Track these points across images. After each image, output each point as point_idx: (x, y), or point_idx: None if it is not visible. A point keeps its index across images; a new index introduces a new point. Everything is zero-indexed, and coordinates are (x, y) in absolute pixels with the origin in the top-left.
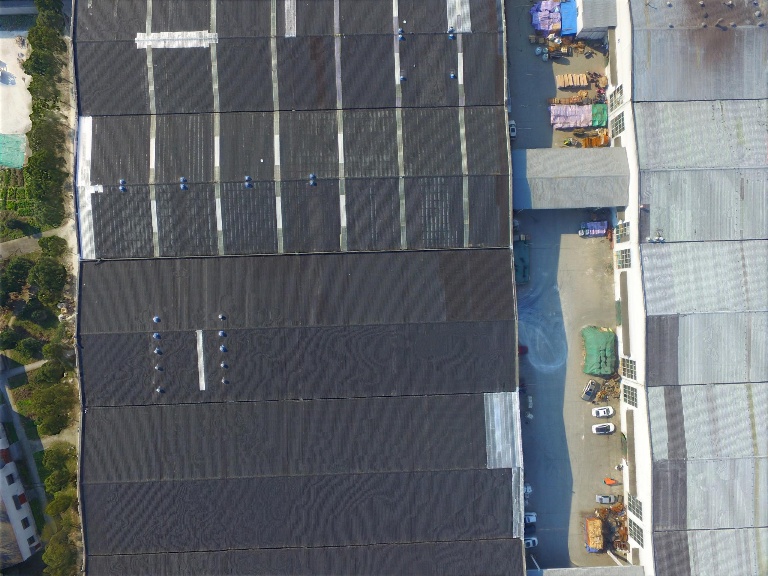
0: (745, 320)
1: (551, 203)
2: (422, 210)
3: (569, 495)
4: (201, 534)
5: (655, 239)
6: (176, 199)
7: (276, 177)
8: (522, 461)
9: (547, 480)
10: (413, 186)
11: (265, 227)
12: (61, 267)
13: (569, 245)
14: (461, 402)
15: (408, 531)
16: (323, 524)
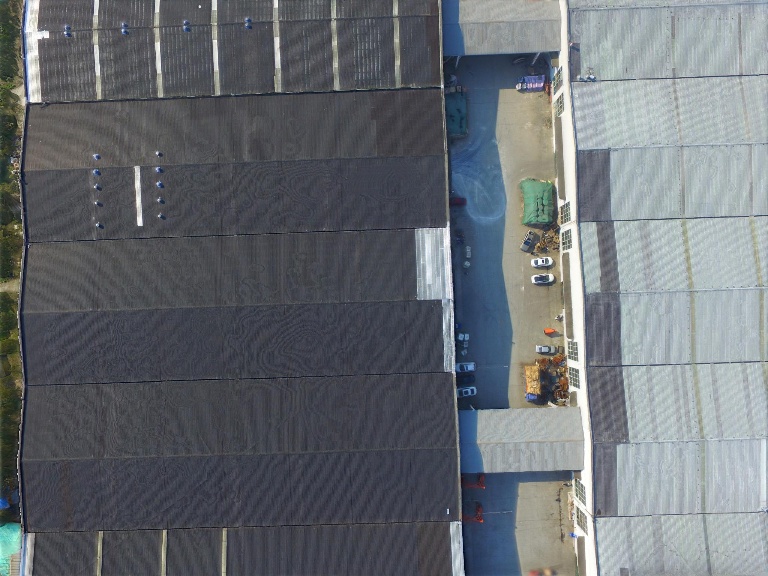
0: (678, 154)
1: (484, 49)
2: (354, 51)
3: (509, 346)
4: (137, 366)
5: (586, 78)
6: (118, 43)
7: (213, 21)
8: (452, 292)
9: (486, 331)
10: (345, 28)
11: (202, 70)
12: (11, 115)
13: (507, 100)
14: (392, 237)
15: (340, 365)
16: (256, 358)
